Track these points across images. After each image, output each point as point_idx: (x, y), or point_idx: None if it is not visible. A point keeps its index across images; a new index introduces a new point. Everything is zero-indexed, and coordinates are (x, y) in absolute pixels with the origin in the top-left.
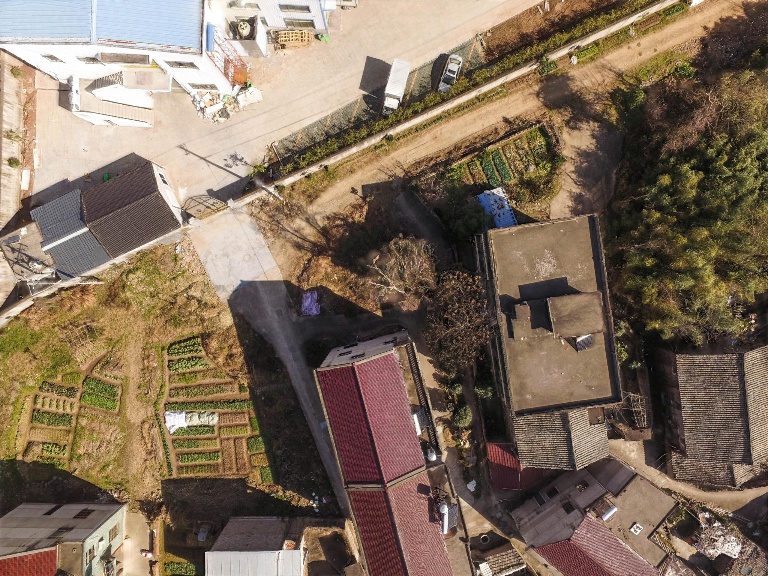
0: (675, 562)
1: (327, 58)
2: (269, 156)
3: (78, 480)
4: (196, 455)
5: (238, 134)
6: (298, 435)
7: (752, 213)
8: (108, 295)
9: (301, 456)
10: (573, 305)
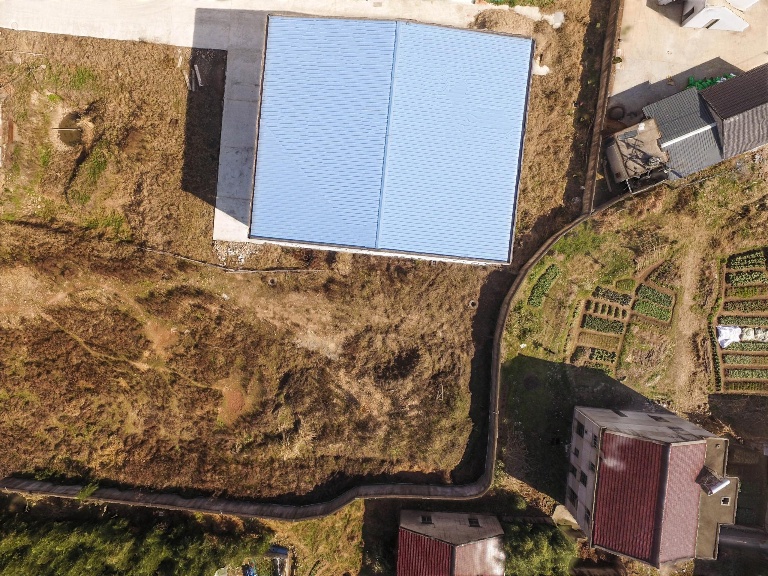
0: None
1: None
2: None
3: (625, 388)
4: (747, 371)
5: None
6: None
7: None
8: (676, 202)
9: None
10: None
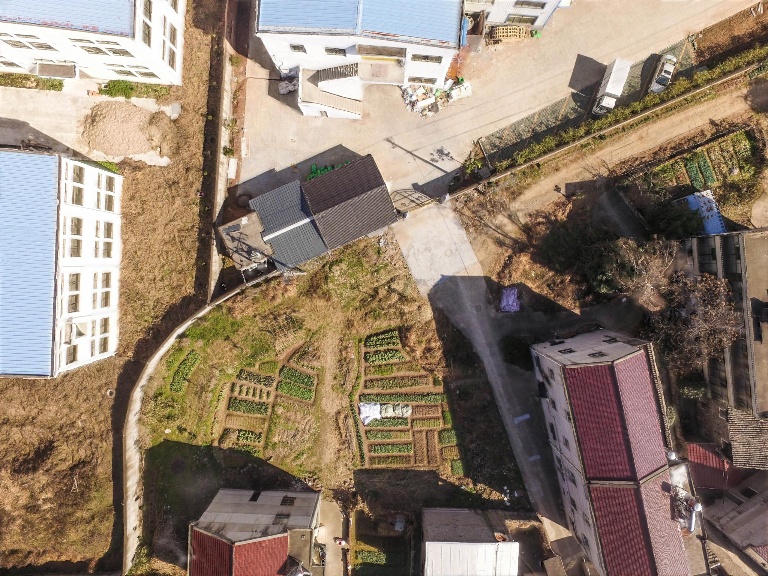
0: None
1: (538, 55)
2: (475, 152)
3: (272, 468)
4: (389, 446)
5: (446, 129)
6: (492, 429)
7: None
8: (309, 286)
9: (494, 450)
10: None
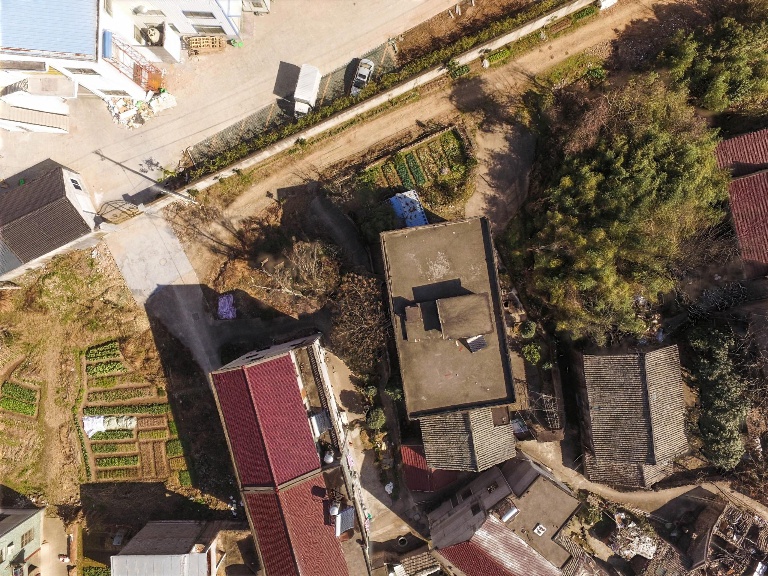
0: (588, 563)
1: (241, 63)
2: (184, 161)
3: None
4: (115, 459)
5: (153, 139)
6: (215, 438)
7: (651, 214)
8: (25, 300)
9: (219, 459)
10: (461, 306)
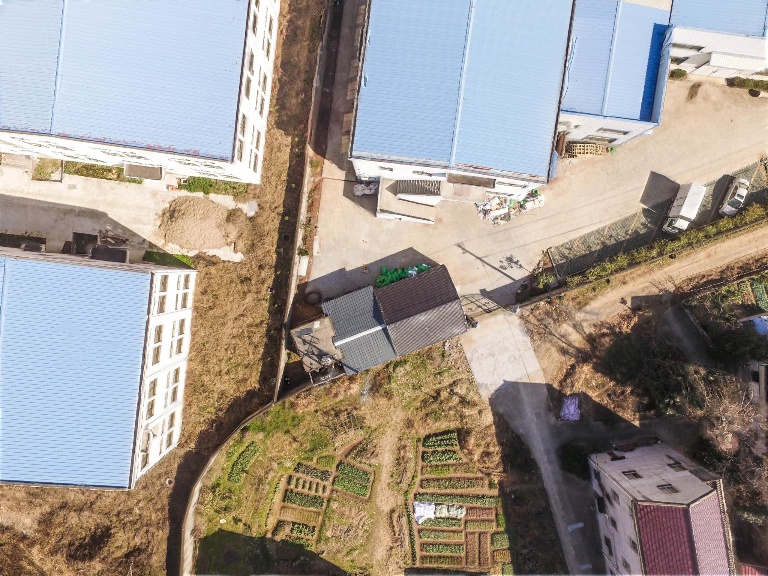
0: None
1: (611, 170)
2: (543, 261)
3: (324, 562)
4: (441, 546)
5: (516, 237)
6: (546, 536)
7: None
8: (372, 384)
9: (546, 557)
10: None
